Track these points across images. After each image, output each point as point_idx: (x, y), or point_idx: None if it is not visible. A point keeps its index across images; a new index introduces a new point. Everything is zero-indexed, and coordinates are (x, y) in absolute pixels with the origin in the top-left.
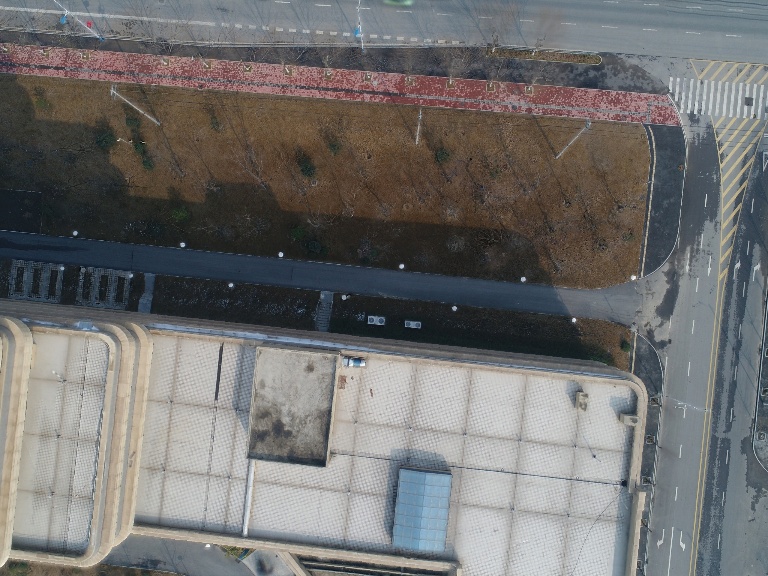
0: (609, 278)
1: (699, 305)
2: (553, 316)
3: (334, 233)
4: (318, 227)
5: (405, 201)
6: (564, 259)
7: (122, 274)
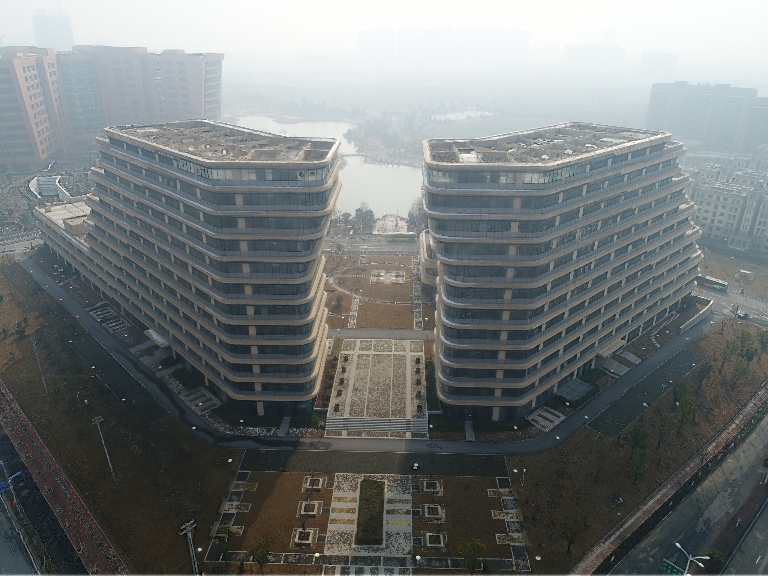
0: (6, 258)
1: (5, 248)
2: (31, 259)
3: (28, 290)
4: (28, 292)
5: (0, 285)
6: (4, 263)
7: (92, 313)
